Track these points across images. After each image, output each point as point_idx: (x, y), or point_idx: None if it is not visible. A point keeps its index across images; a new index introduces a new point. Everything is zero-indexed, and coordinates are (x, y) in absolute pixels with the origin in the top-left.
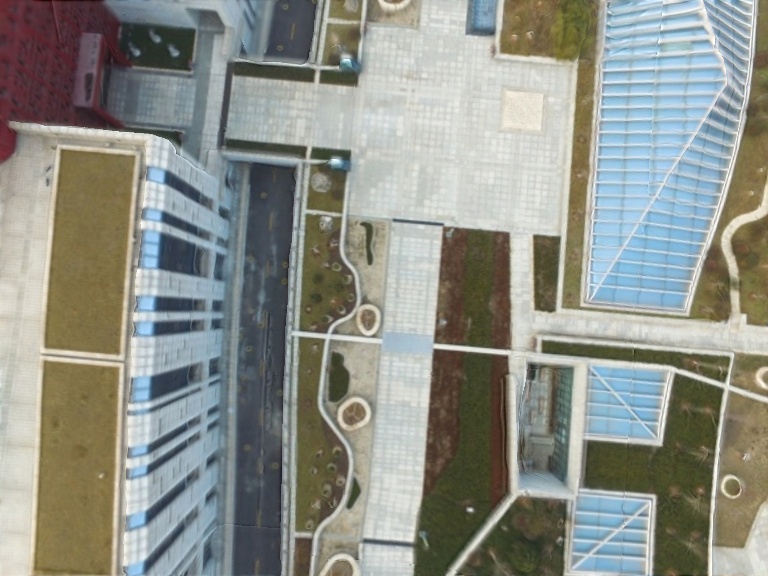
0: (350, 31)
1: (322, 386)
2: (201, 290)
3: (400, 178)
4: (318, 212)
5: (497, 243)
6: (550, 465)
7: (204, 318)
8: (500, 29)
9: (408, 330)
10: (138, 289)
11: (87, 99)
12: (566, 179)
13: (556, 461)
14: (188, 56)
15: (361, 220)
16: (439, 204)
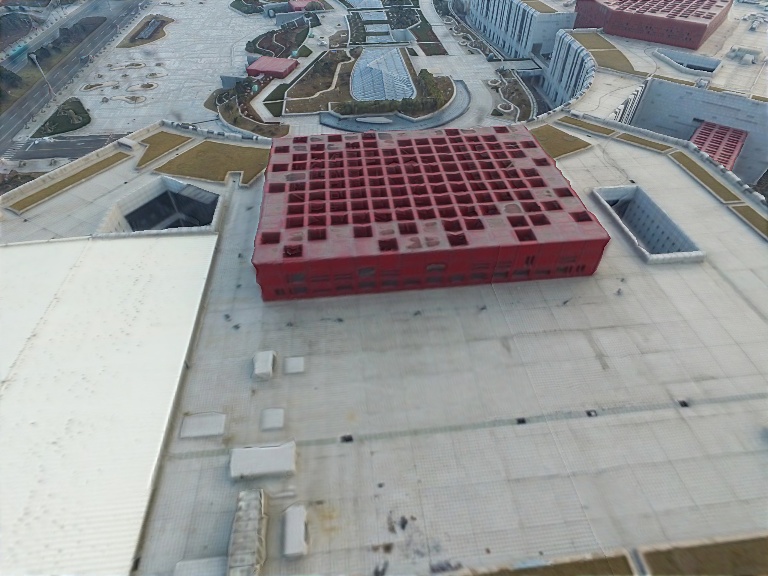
0: (506, 76)
1: None
2: None
3: None
4: None
5: None
6: None
7: None
8: None
9: None
10: None
11: None
12: None
13: None
14: None
15: None
16: None
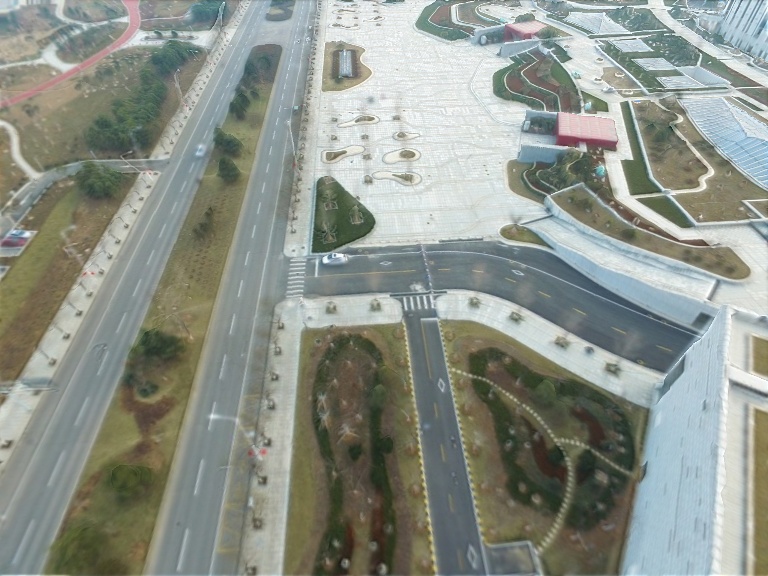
0: None
1: None
2: None
3: None
4: None
5: None
6: None
7: None
8: None
9: None
10: None
11: None
12: None
13: None
14: None
15: None
16: None
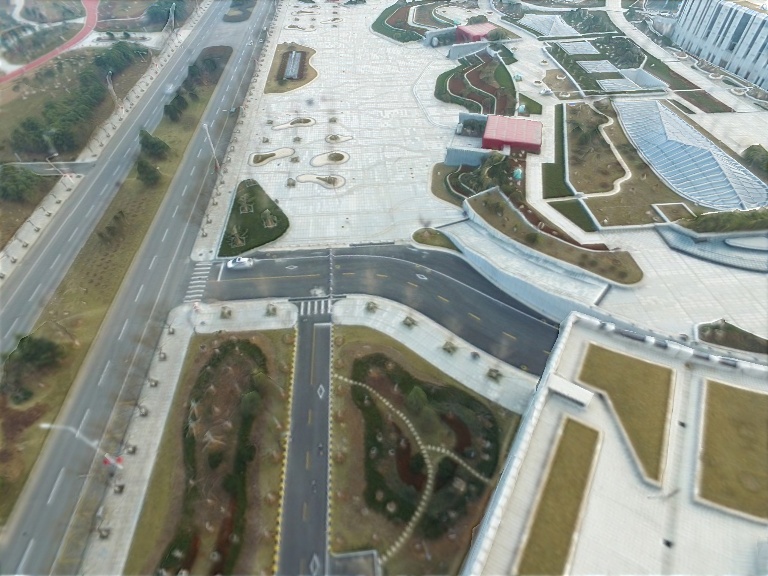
0: None
1: None
2: None
3: None
4: None
5: None
6: None
7: None
8: None
9: None
10: None
11: None
12: None
13: None
14: None
15: None
16: None
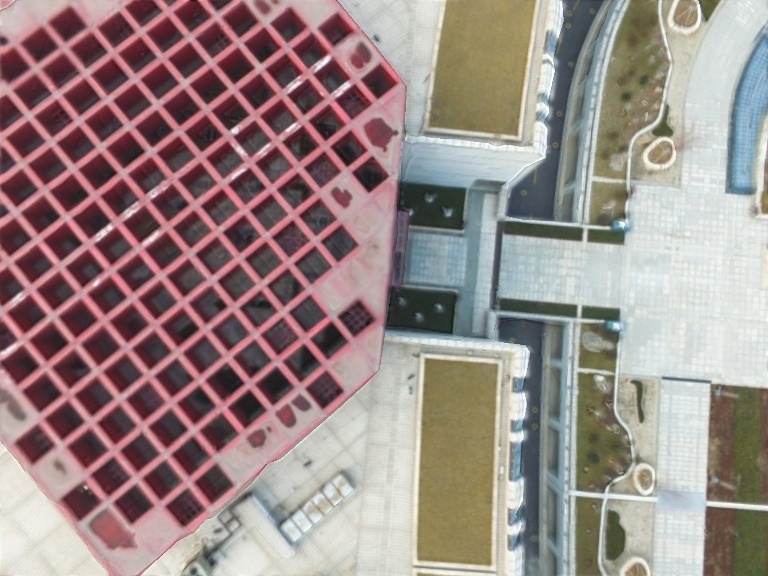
0: (617, 191)
1: (600, 545)
2: None
3: (668, 336)
4: (590, 371)
5: (763, 400)
6: None
7: None
8: (762, 190)
9: (681, 488)
10: (513, 502)
11: (396, 278)
12: None
13: None
14: (459, 215)
15: (632, 378)
16: (706, 362)
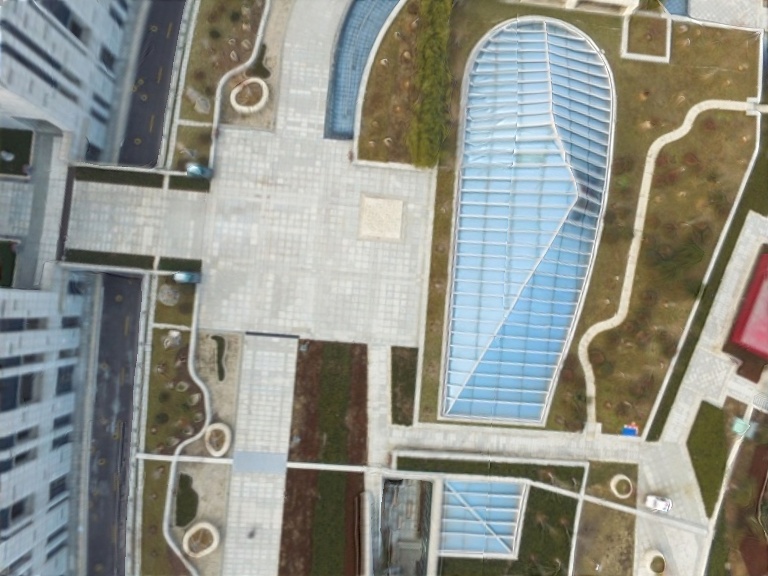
0: (201, 134)
1: (168, 511)
2: (31, 418)
3: (254, 289)
4: (166, 326)
5: (354, 355)
6: (417, 571)
7: (38, 444)
8: (358, 134)
9: (260, 448)
10: None
11: None
12: (424, 289)
13: (421, 569)
14: (24, 159)
15: (212, 333)
16: (294, 316)
